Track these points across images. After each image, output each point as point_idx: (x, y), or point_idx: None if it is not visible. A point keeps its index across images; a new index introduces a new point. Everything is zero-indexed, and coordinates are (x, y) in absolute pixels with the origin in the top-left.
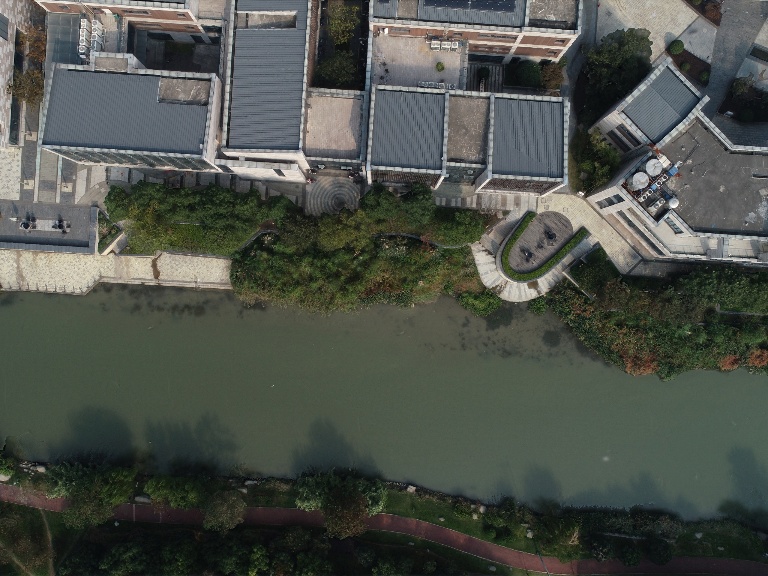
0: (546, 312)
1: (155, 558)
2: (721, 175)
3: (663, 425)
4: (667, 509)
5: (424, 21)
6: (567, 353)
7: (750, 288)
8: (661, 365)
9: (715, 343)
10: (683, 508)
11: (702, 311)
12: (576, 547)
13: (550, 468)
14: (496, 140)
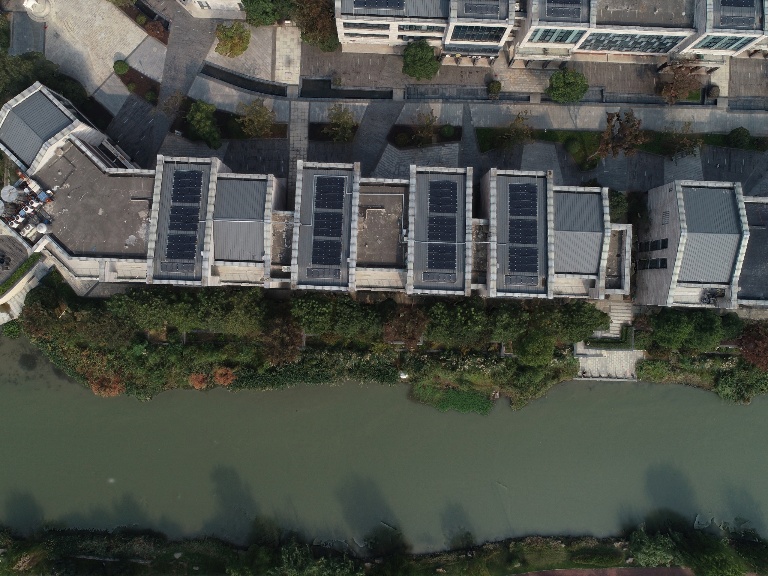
0: (21, 336)
1: None
2: (99, 198)
3: (146, 445)
4: (150, 530)
5: None
6: (44, 376)
7: (166, 309)
8: (125, 386)
9: (172, 363)
10: (167, 528)
11: (130, 333)
12: (25, 572)
13: (31, 492)
14: None
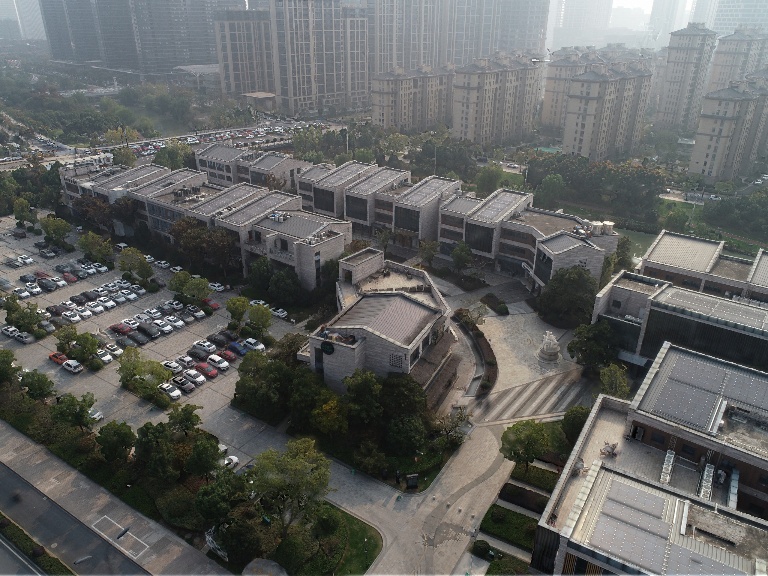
0: None
1: None
2: None
3: None
4: None
5: (767, 310)
6: None
7: None
8: None
9: None
10: None
11: None
12: None
13: None
14: (711, 256)
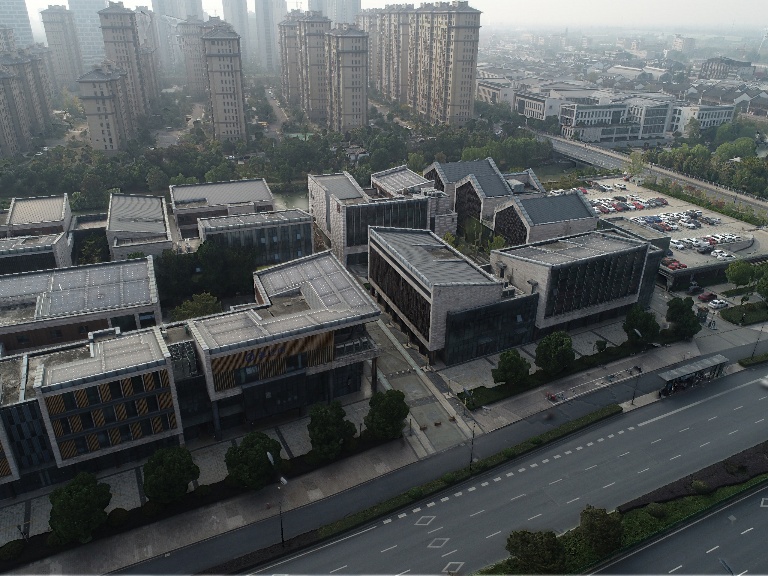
0: None
1: (186, 169)
2: None
3: None
4: None
5: (21, 238)
6: None
7: None
8: None
9: None
10: None
11: None
12: None
13: None
14: None
